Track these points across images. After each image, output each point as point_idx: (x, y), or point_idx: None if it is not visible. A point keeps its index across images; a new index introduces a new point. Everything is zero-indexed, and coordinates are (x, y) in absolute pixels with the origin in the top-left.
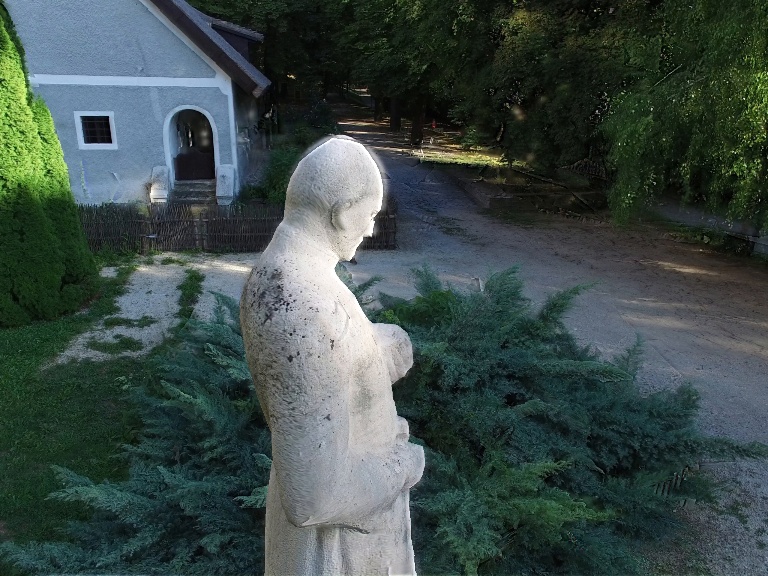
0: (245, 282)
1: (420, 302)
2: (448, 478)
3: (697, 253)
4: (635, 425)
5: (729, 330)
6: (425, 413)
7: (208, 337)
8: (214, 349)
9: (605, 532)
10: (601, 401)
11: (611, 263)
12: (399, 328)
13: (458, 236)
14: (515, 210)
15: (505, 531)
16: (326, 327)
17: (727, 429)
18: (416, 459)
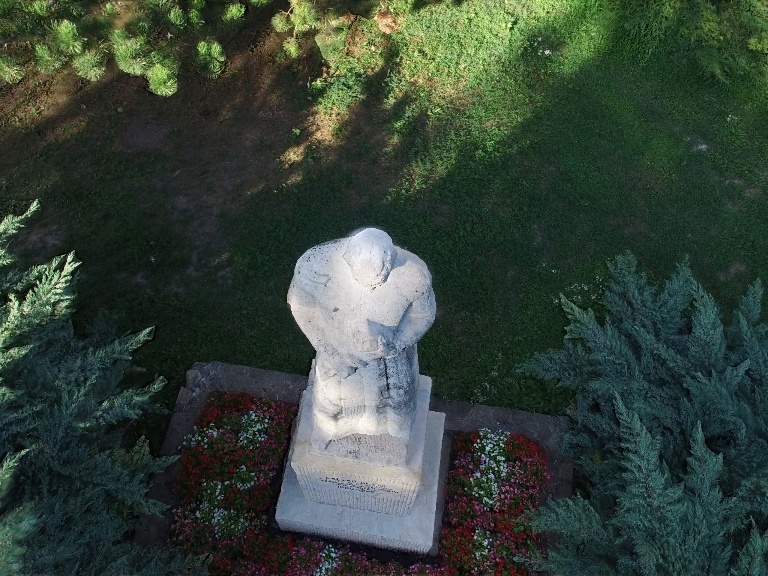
0: None
1: None
2: None
3: None
4: None
5: None
6: None
7: None
8: None
9: None
10: None
11: None
12: (367, 337)
13: None
14: None
15: None
16: (303, 268)
17: None
18: (337, 368)
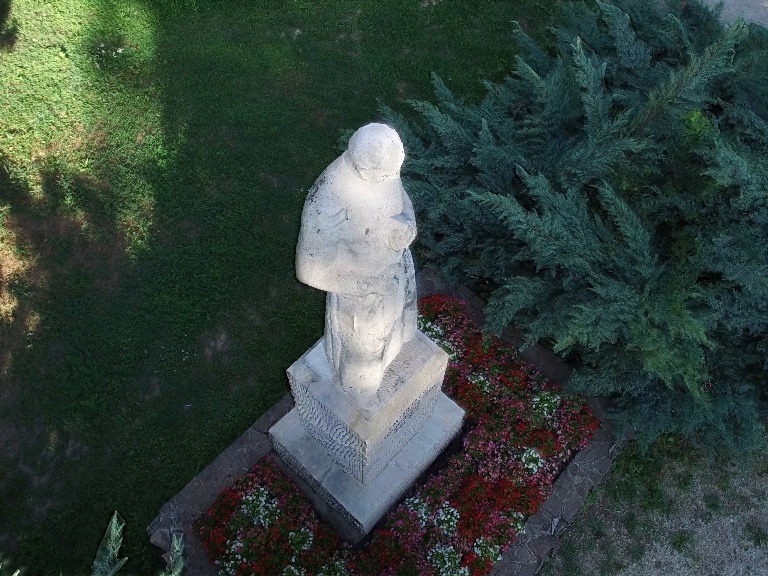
0: None
1: None
2: (640, 278)
3: None
4: None
5: None
6: None
7: (628, 7)
8: (580, 45)
9: (748, 407)
10: None
11: None
12: (405, 228)
13: None
14: None
15: None
16: (319, 223)
17: None
18: (387, 288)
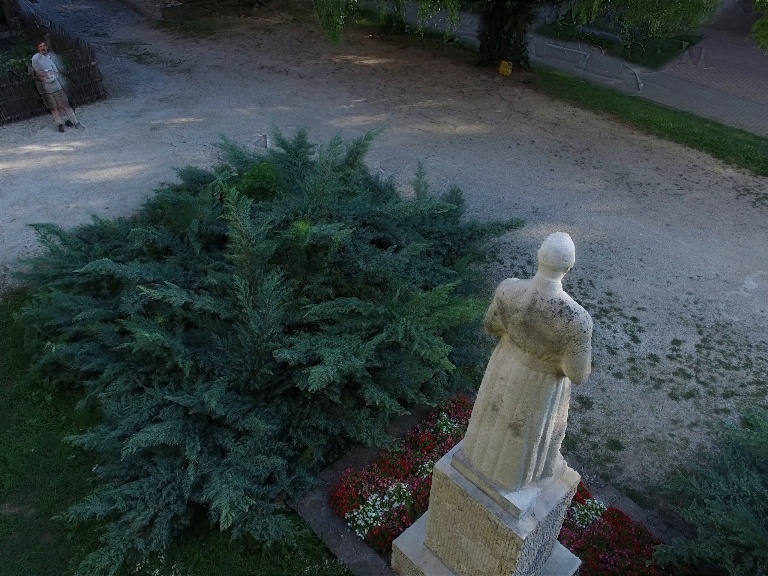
0: (529, 304)
1: (249, 178)
2: None
3: (370, 39)
4: (443, 229)
5: (428, 116)
6: (335, 276)
7: (56, 270)
8: (145, 288)
9: None
10: (417, 219)
11: (312, 67)
12: None
13: (156, 64)
14: (190, 18)
15: (436, 333)
16: None
17: (466, 202)
18: None
